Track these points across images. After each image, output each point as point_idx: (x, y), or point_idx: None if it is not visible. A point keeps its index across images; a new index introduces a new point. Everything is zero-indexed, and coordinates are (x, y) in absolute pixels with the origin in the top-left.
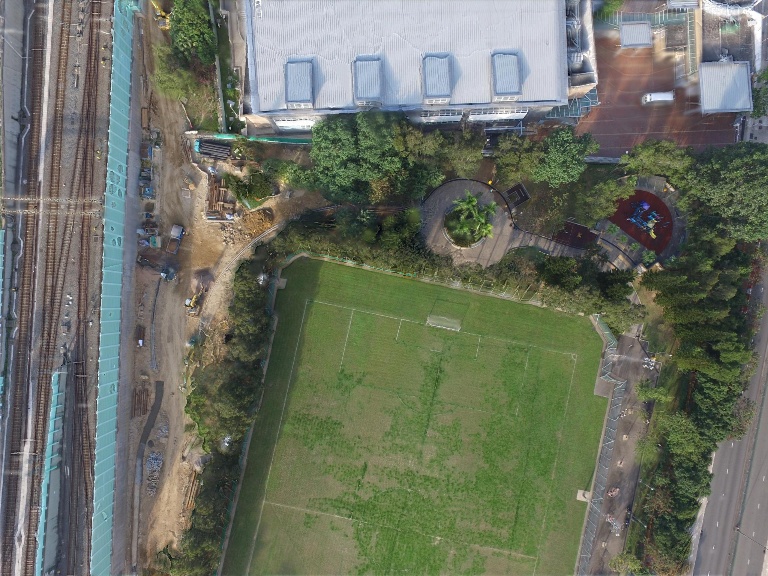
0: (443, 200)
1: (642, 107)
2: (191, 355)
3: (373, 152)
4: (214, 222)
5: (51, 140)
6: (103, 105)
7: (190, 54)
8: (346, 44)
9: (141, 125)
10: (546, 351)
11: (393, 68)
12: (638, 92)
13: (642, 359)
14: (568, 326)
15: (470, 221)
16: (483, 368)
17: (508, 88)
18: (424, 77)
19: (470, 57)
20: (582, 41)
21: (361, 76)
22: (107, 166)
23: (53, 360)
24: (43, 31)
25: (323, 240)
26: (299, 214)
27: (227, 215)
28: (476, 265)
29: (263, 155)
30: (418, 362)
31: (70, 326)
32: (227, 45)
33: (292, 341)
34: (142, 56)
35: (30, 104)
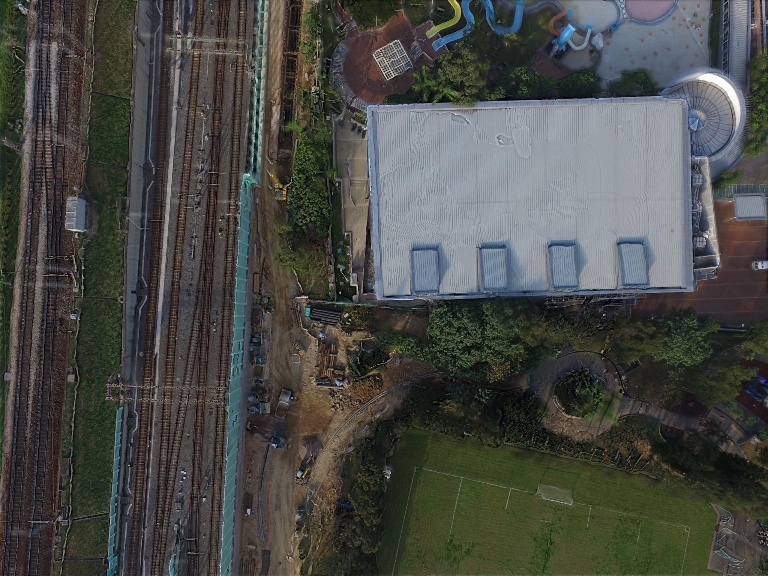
0: (556, 370)
1: (753, 273)
2: (302, 529)
3: (500, 342)
4: (323, 387)
5: (168, 312)
6: (219, 276)
7: (308, 228)
8: (450, 200)
9: (252, 290)
10: (659, 523)
11: (519, 256)
12: (747, 256)
13: (757, 533)
14: (680, 497)
15: (584, 394)
16: (594, 540)
17: (637, 281)
18: (551, 267)
19: (596, 246)
20: (701, 220)
21: (487, 265)
22: (232, 352)
23: (167, 538)
24: (162, 202)
25: (450, 433)
26: (408, 380)
27: (337, 382)
28: (587, 434)
29: (377, 326)
30: (528, 533)
31: (183, 502)
32: (338, 210)
33: (400, 510)
34: (256, 224)
35: (147, 275)
